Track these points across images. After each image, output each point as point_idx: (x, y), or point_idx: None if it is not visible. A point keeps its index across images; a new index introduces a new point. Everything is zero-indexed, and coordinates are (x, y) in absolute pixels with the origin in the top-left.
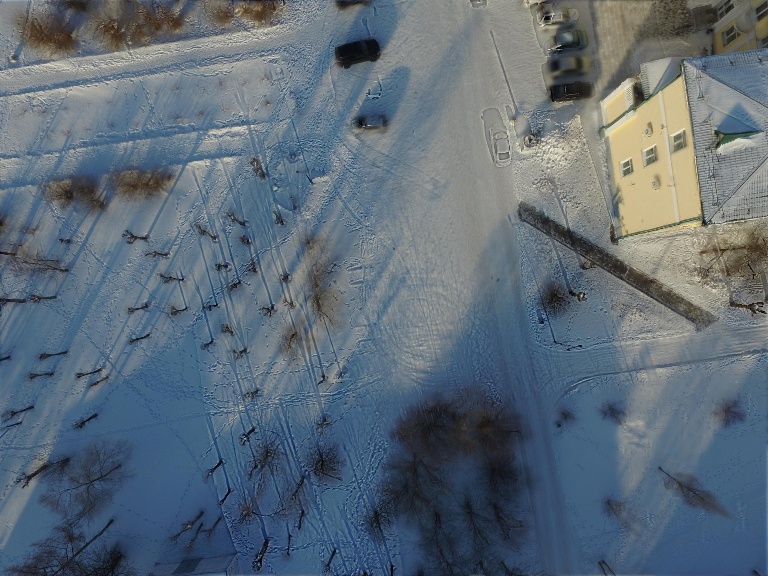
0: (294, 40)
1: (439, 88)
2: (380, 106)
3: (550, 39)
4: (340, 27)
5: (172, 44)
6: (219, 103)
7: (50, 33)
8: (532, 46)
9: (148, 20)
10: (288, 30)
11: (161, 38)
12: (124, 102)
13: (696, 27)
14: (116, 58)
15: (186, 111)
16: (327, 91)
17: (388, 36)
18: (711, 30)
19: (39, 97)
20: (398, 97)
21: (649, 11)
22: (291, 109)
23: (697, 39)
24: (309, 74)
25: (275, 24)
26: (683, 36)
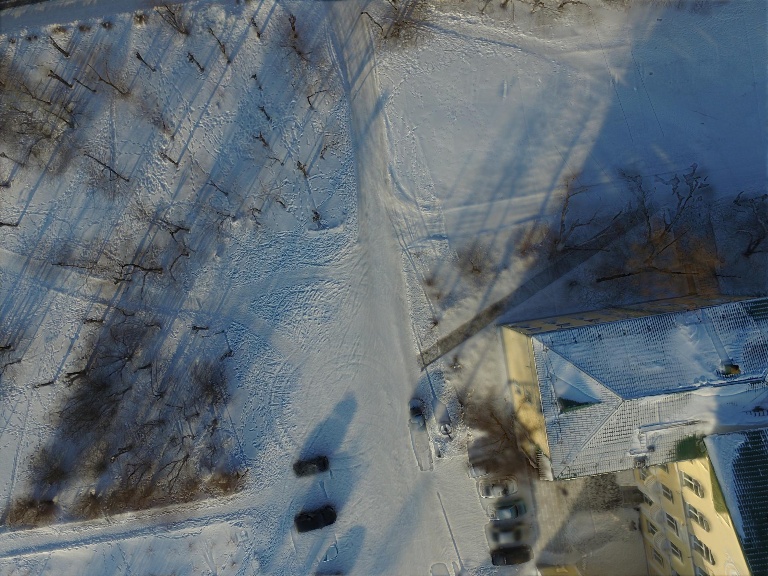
0: (257, 503)
1: (391, 545)
2: (337, 562)
3: (492, 503)
4: (299, 490)
5: (145, 511)
6: (189, 563)
7: (34, 499)
8: (476, 508)
9: (123, 487)
10: (251, 494)
11: (135, 505)
12: (102, 562)
13: (624, 502)
14: (94, 524)
15: (159, 570)
16: (288, 549)
17: (343, 497)
18: (637, 510)
19: (25, 559)
20: (353, 554)
21: (581, 486)
22: (255, 569)
23: (625, 513)
24: (271, 535)
25: (239, 490)
26: (613, 510)
